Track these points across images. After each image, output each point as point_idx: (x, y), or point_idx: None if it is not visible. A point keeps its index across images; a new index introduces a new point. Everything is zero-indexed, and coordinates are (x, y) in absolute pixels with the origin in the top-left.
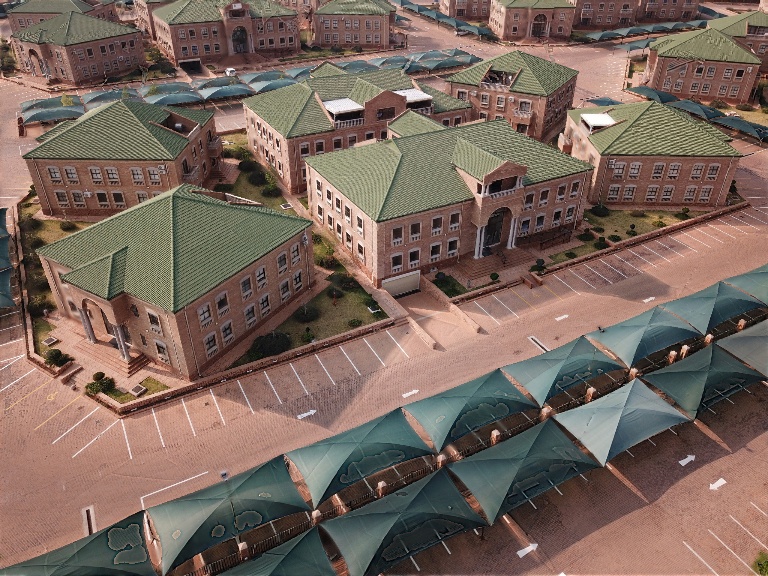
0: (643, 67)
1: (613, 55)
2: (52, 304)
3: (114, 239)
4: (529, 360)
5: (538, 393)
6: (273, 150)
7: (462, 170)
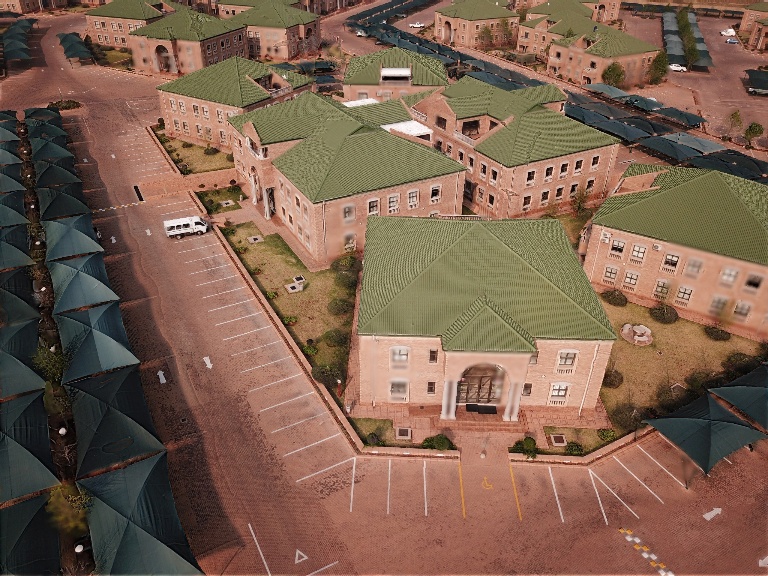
0: (121, 67)
1: (72, 67)
2: (760, 348)
3: (767, 214)
4: (674, 150)
5: (694, 154)
6: (415, 211)
7: (548, 103)
